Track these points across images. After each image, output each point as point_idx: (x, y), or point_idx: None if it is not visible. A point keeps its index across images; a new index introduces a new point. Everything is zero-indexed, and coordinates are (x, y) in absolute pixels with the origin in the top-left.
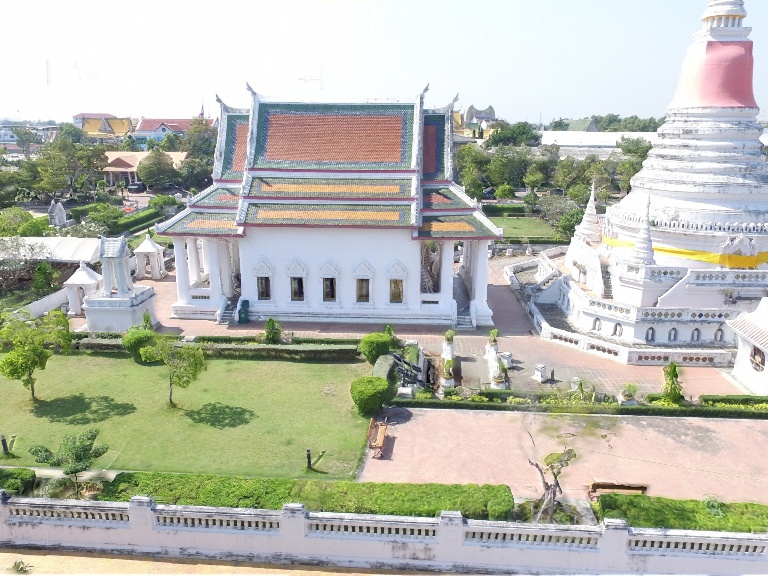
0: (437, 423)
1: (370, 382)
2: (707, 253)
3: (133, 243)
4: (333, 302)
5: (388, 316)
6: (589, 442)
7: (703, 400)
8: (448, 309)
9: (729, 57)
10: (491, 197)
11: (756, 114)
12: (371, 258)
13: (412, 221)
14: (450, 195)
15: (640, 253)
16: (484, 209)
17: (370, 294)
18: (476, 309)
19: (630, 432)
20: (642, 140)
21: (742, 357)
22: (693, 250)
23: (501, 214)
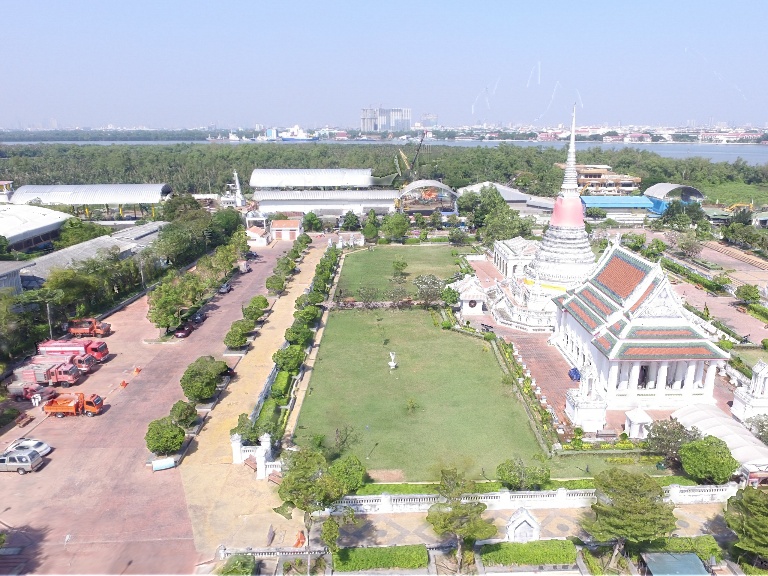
0: None
1: None
2: None
3: None
4: None
5: None
6: None
7: None
8: None
9: None
10: None
11: None
12: None
13: None
14: None
15: None
16: None
17: None
18: None
19: None
20: None
21: None
22: None
23: None
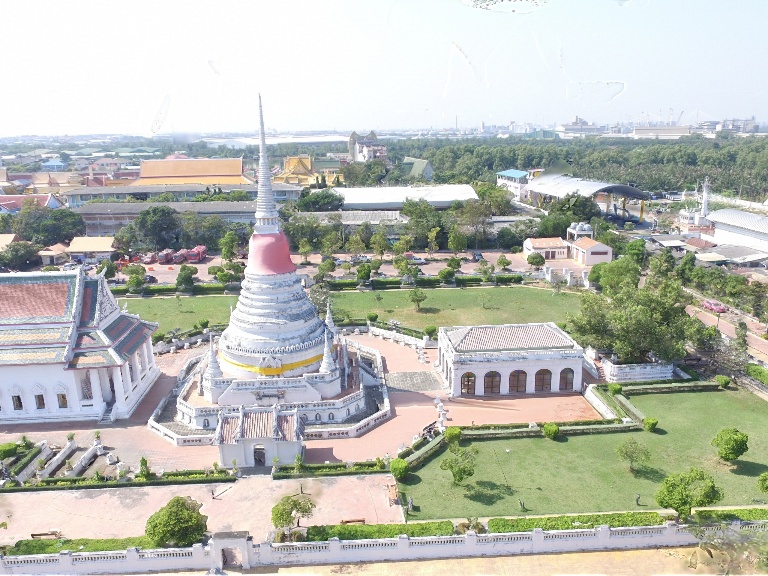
0: (2, 503)
1: None
2: (254, 367)
3: None
4: (21, 410)
5: (59, 417)
6: (73, 508)
7: (163, 475)
8: (99, 410)
9: (264, 245)
10: None
11: (289, 276)
12: (42, 381)
13: (62, 359)
14: (96, 337)
15: (209, 370)
16: None
17: (45, 404)
18: (117, 408)
19: (103, 499)
20: (423, 200)
21: None
22: (247, 365)
23: None
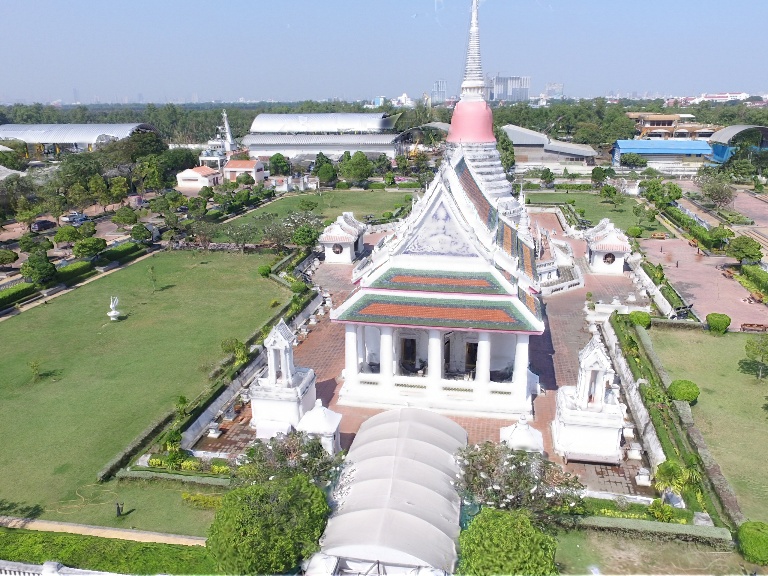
0: None
1: (721, 315)
2: None
3: (68, 501)
4: None
5: None
6: (710, 298)
7: None
8: None
9: None
10: (7, 248)
11: None
12: None
13: None
14: None
15: None
16: (109, 258)
17: None
18: None
19: None
20: None
21: (598, 262)
22: None
23: (130, 258)
